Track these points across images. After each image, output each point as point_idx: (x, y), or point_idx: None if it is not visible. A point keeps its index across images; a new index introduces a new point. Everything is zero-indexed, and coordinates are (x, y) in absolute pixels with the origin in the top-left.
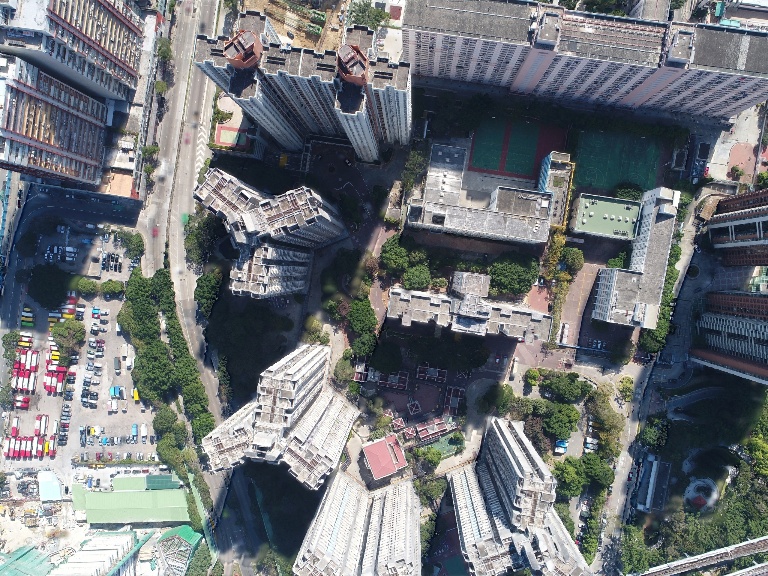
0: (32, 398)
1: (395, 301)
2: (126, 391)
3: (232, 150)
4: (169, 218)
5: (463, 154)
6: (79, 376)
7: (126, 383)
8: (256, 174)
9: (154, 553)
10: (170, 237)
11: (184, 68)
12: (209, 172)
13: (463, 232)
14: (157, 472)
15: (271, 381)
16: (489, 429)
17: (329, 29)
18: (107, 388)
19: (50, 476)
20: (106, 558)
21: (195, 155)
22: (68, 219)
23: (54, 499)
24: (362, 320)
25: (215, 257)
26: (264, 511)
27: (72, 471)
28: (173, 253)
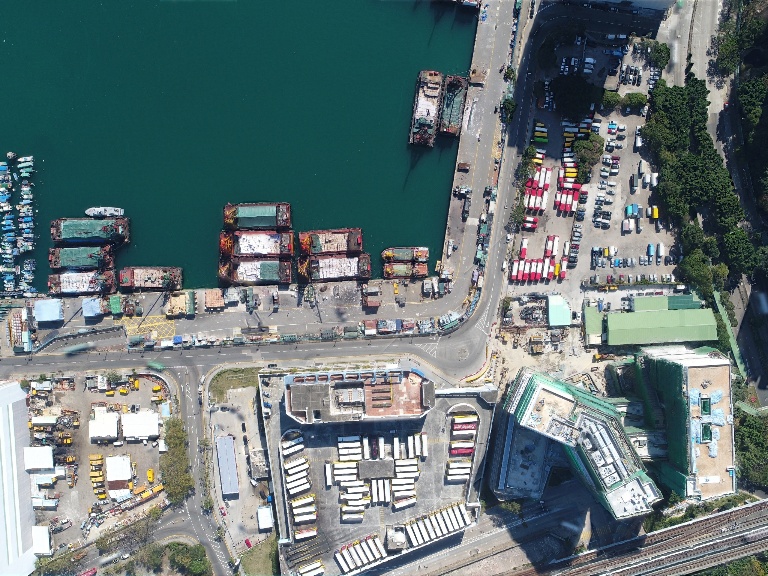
0: (539, 219)
1: None
2: None
3: None
4: (692, 29)
5: None
6: (590, 195)
7: (640, 202)
8: None
9: None
10: (692, 49)
11: None
12: None
13: None
14: (671, 294)
15: None
16: None
17: None
18: (620, 208)
19: (561, 299)
20: (707, 355)
21: None
22: None
23: (564, 324)
24: None
25: None
26: None
27: (580, 295)
28: (694, 66)
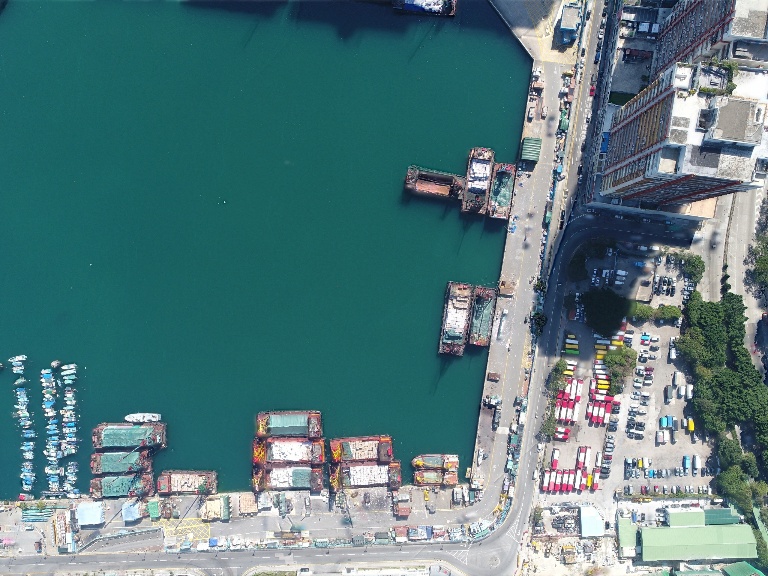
0: (571, 429)
1: None
2: None
3: None
4: (727, 239)
5: None
6: (623, 406)
7: (675, 413)
8: None
9: None
10: (728, 259)
11: None
12: None
13: None
14: (708, 506)
15: None
16: None
17: None
18: (654, 418)
19: (594, 511)
20: None
21: None
22: None
23: (597, 535)
24: None
25: None
26: None
27: (613, 505)
28: (731, 276)
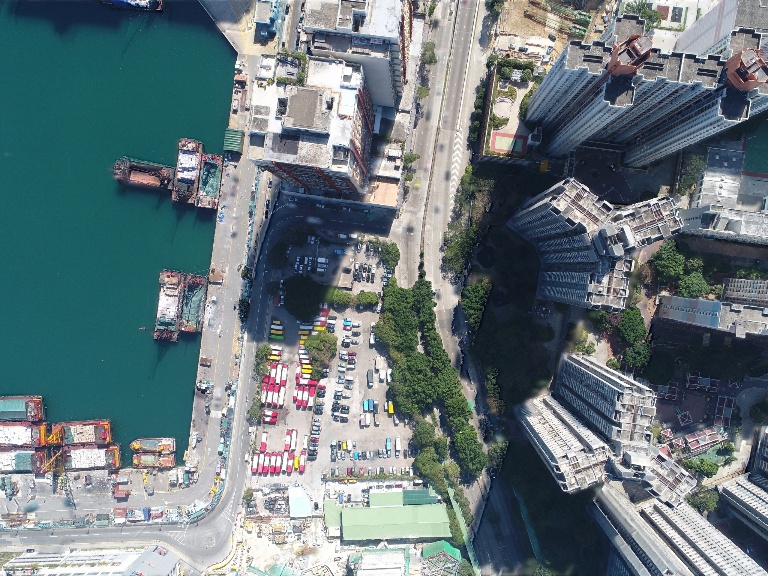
0: (280, 412)
1: (725, 312)
2: (378, 404)
3: (510, 157)
4: (424, 227)
5: (741, 158)
6: (329, 390)
7: (378, 396)
8: (524, 181)
9: (422, 570)
10: (424, 246)
11: (440, 73)
12: (565, 182)
13: (744, 238)
14: (411, 487)
15: (631, 398)
16: (763, 439)
17: (593, 31)
18: (358, 401)
19: (301, 492)
20: None
21: (451, 162)
22: (317, 229)
23: (305, 515)
24: (636, 329)
25: (478, 266)
26: (533, 526)
27: (321, 486)
28: (428, 263)
